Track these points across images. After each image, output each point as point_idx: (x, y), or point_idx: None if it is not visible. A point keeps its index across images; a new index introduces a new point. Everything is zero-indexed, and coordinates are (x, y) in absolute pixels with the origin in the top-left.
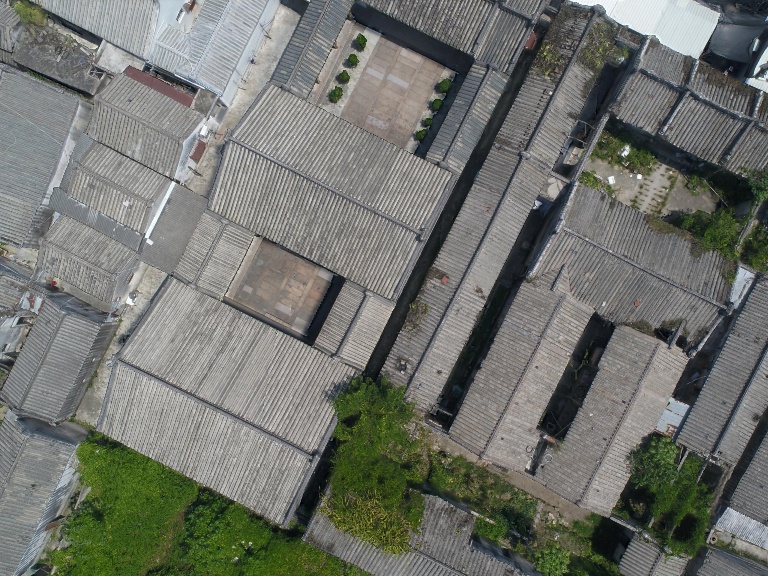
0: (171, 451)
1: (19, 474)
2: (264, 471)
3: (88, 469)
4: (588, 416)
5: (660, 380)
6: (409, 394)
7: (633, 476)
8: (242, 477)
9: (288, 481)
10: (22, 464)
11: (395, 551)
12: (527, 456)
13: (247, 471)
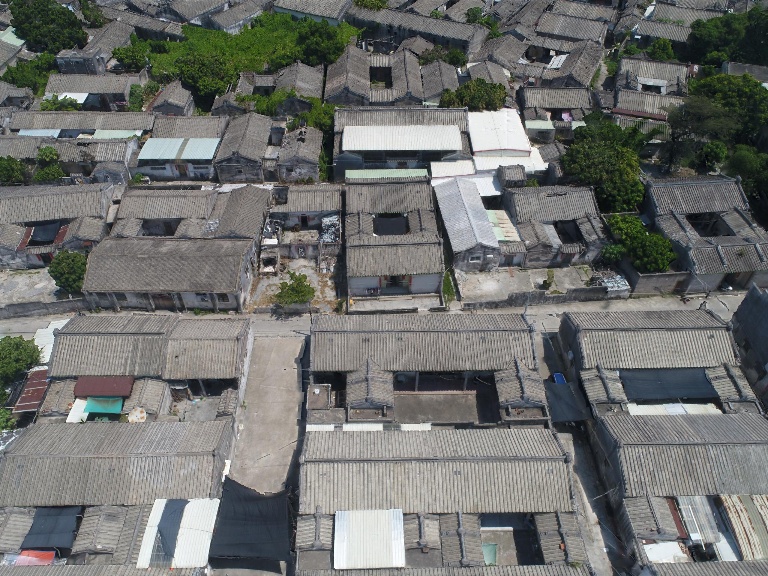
0: (299, 5)
1: (242, 6)
2: (333, 2)
3: (265, 13)
4: (450, 8)
5: (475, 4)
6: (386, 2)
7: (468, 19)
8: (324, 7)
9: (342, 3)
10: (244, 4)
11: (379, 6)
12: (429, 15)
13: (327, 4)
